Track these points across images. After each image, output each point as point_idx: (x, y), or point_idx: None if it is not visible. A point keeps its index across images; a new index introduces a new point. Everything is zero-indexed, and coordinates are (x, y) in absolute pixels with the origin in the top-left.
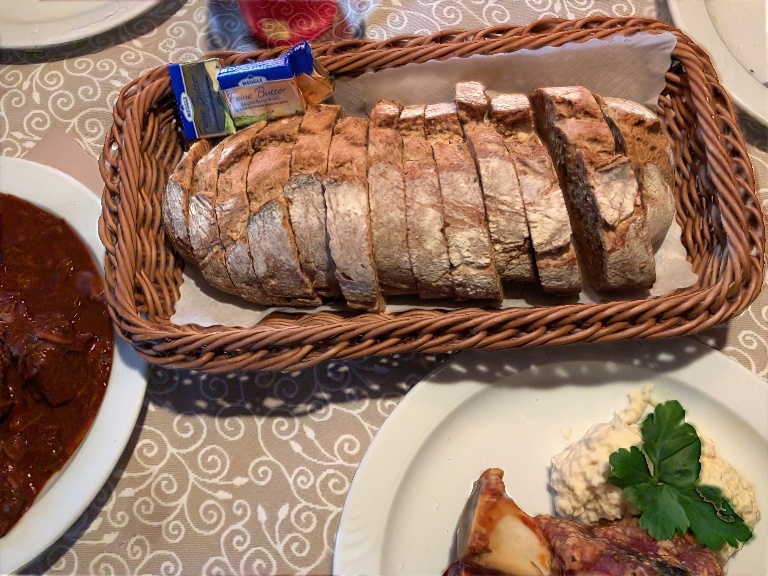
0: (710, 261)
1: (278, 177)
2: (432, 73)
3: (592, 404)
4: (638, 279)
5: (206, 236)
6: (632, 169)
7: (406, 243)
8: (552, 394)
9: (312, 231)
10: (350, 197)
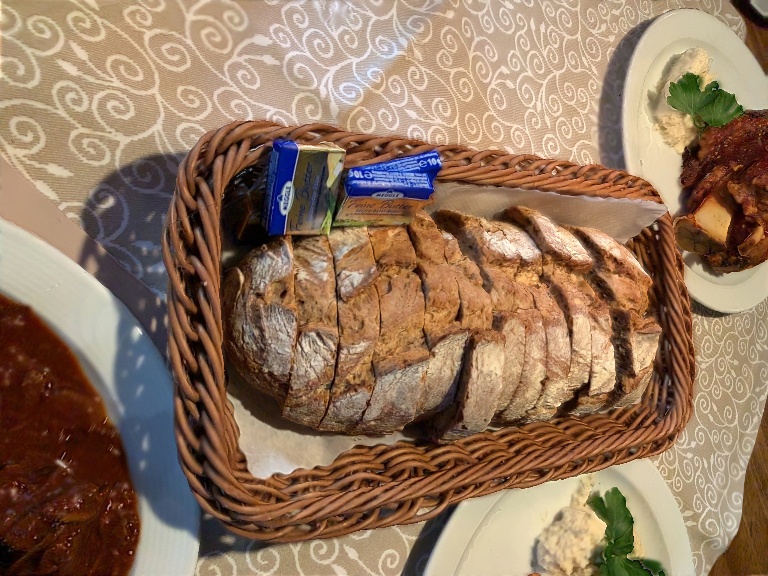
0: (651, 385)
1: (416, 321)
2: (505, 193)
3: (559, 490)
4: (623, 405)
5: (315, 377)
6: None
7: (513, 393)
8: (538, 486)
9: (441, 382)
10: (493, 357)
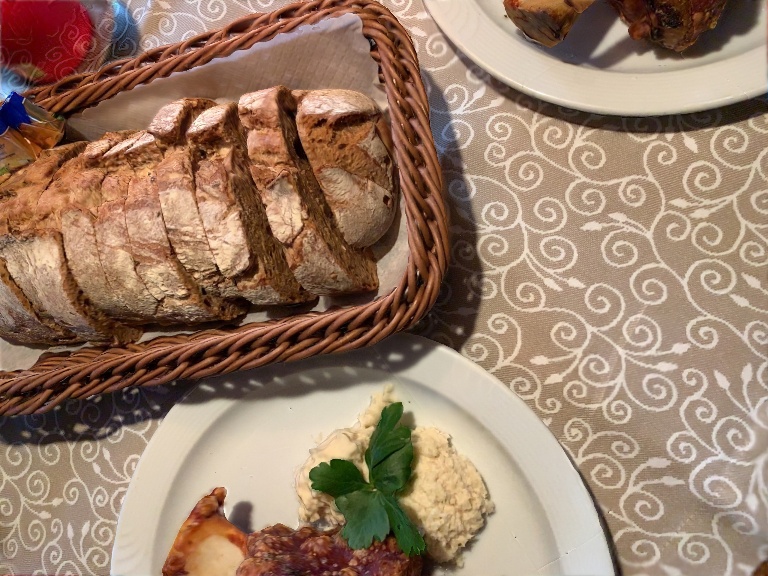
0: None
1: None
2: (151, 95)
3: (341, 408)
4: (339, 287)
5: None
6: (291, 183)
7: (109, 285)
8: (303, 401)
9: None
10: (44, 251)
